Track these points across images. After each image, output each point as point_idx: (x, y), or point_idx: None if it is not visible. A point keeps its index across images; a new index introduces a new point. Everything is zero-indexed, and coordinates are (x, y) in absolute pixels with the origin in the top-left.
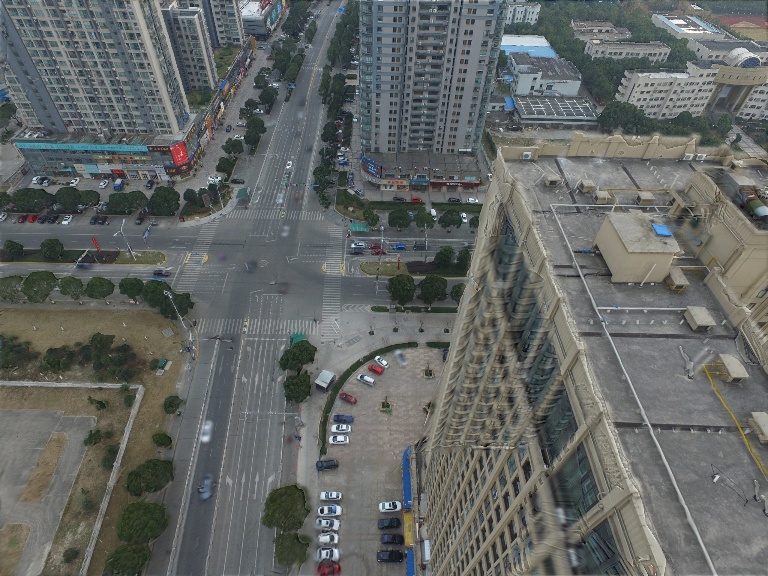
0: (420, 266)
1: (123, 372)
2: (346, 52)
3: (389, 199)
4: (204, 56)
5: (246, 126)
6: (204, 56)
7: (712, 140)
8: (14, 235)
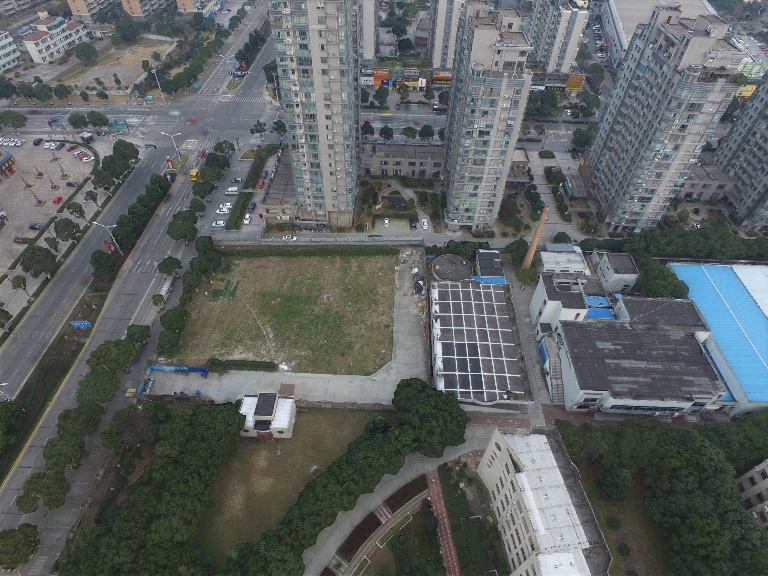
0: (166, 179)
1: (134, 84)
2: (586, 135)
3: (268, 170)
4: (437, 36)
5: (401, 100)
6: (437, 36)
7: (275, 544)
8: (272, 52)
